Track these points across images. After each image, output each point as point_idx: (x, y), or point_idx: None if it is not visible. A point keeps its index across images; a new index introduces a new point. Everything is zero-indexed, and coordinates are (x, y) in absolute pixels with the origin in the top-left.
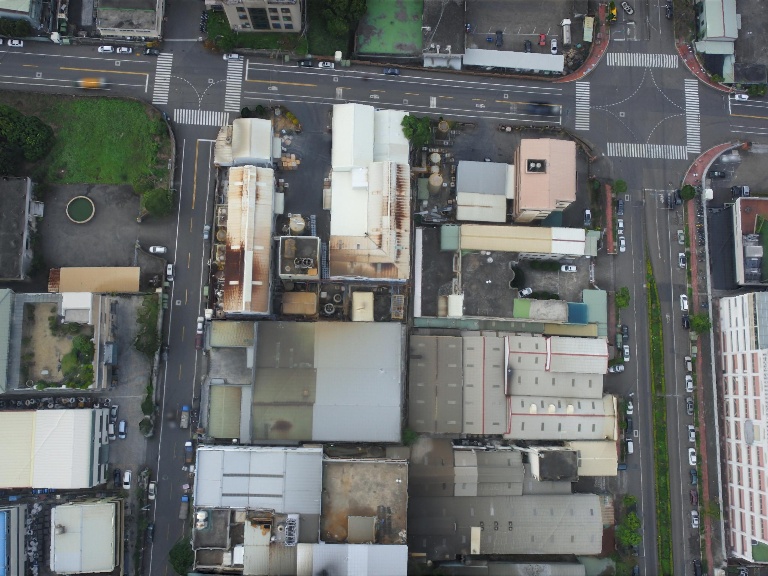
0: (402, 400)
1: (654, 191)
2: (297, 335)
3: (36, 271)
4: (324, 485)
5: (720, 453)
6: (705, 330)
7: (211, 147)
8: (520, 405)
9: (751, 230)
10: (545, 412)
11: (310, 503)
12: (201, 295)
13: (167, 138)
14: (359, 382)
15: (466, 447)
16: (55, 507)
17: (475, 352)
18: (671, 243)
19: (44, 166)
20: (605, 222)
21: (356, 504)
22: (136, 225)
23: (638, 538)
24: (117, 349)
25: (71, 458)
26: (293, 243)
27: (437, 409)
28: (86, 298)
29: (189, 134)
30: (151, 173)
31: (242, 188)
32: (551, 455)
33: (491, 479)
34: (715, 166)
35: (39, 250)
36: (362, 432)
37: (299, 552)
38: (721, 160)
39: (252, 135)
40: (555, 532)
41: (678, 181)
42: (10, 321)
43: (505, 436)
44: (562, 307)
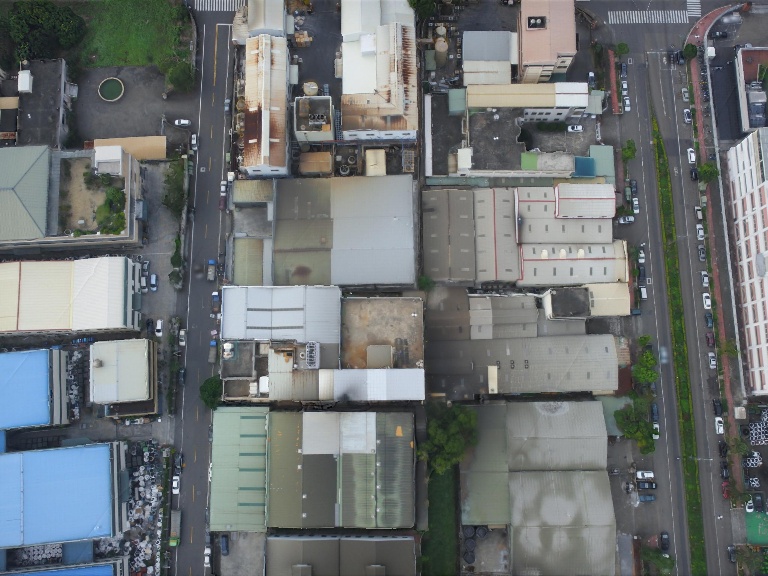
0: (416, 249)
1: (657, 54)
2: (314, 190)
3: (72, 142)
4: (343, 321)
5: (735, 298)
6: (713, 177)
7: (229, 30)
8: (531, 252)
9: (754, 79)
10: (556, 257)
11: (330, 333)
12: (224, 162)
13: (188, 22)
14: (374, 229)
15: (481, 295)
16: (93, 344)
17: (486, 204)
18: (676, 101)
19: (77, 53)
20: (609, 85)
21: (374, 337)
22: (162, 101)
23: (654, 374)
24: (147, 207)
25: (107, 300)
26: (307, 102)
27: (450, 256)
28: (117, 151)
29: (209, 20)
30: (175, 54)
31: (258, 55)
32: (563, 293)
33: (506, 320)
34: (716, 28)
35: (74, 126)
36: (378, 275)
37: (321, 378)
38: (722, 22)
39: (266, 9)
40: (571, 369)
41: (680, 43)
42: (49, 174)
43: (518, 282)
44: (569, 158)
